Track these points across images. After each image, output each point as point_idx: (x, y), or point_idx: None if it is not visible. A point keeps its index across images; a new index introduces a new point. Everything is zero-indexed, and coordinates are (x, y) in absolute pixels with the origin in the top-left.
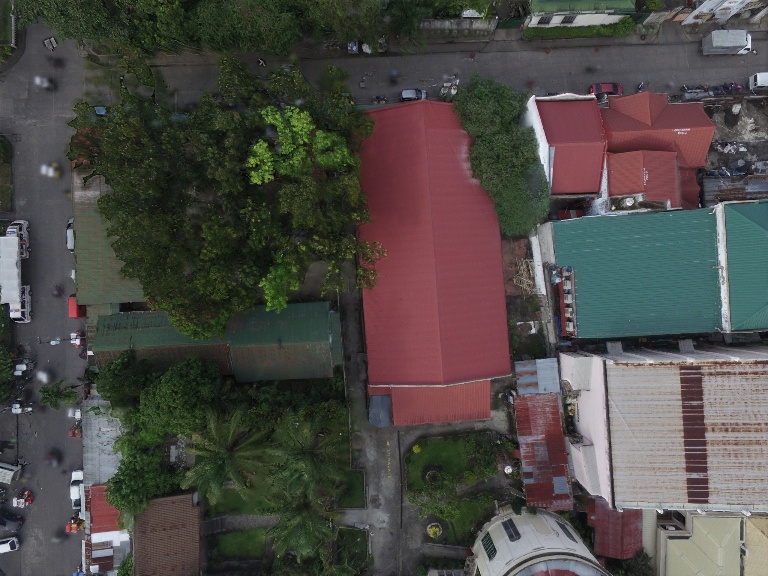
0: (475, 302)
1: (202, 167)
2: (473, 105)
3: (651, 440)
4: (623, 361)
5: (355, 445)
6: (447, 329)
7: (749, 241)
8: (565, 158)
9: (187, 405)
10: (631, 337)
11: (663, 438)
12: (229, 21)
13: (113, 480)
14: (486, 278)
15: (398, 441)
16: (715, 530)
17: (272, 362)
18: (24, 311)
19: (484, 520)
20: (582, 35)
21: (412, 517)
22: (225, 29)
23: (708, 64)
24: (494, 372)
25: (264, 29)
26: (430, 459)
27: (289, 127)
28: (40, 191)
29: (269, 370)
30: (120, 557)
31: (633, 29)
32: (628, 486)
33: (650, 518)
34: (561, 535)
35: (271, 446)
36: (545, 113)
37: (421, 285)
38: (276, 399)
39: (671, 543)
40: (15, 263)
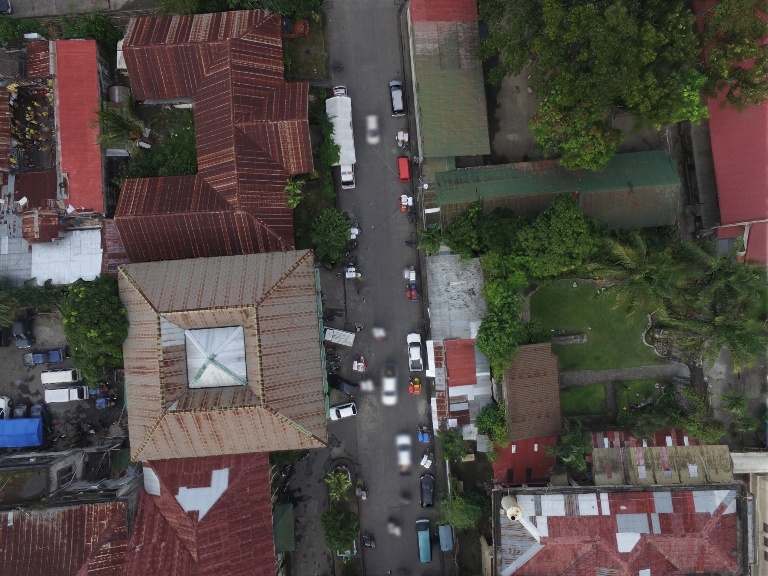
0: None
1: None
2: None
3: None
4: None
5: None
6: None
7: None
8: None
9: (587, 232)
10: None
11: None
12: None
13: (496, 320)
14: None
15: None
16: None
17: (618, 209)
18: (353, 175)
19: None
20: None
21: (749, 367)
22: None
23: None
24: None
25: None
26: (764, 308)
27: None
28: (355, 57)
29: (613, 219)
30: (475, 411)
31: None
32: None
33: None
34: None
35: None
36: None
37: None
38: None
39: None
40: (349, 123)
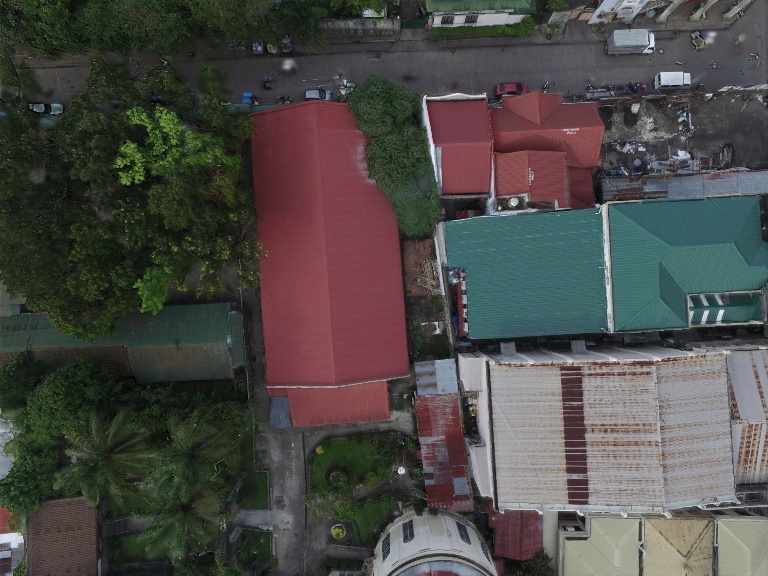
0: (370, 303)
1: None
2: (365, 105)
3: (533, 441)
4: (505, 362)
5: (259, 446)
6: (340, 330)
7: (631, 241)
8: (453, 158)
9: (70, 407)
10: (529, 337)
11: (544, 439)
12: (115, 22)
13: (2, 482)
14: (383, 279)
15: (303, 442)
16: (612, 531)
17: (171, 363)
18: None
19: (387, 521)
20: (487, 35)
21: (317, 518)
22: (112, 30)
23: (614, 64)
24: (390, 373)
25: (149, 29)
26: (335, 460)
27: (158, 128)
28: None
29: (169, 371)
30: (18, 559)
31: (538, 29)
32: (511, 487)
33: (550, 519)
34: (453, 536)
35: (154, 448)
36: (435, 113)
37: (314, 286)
38: (170, 400)
39: (569, 544)
40: None
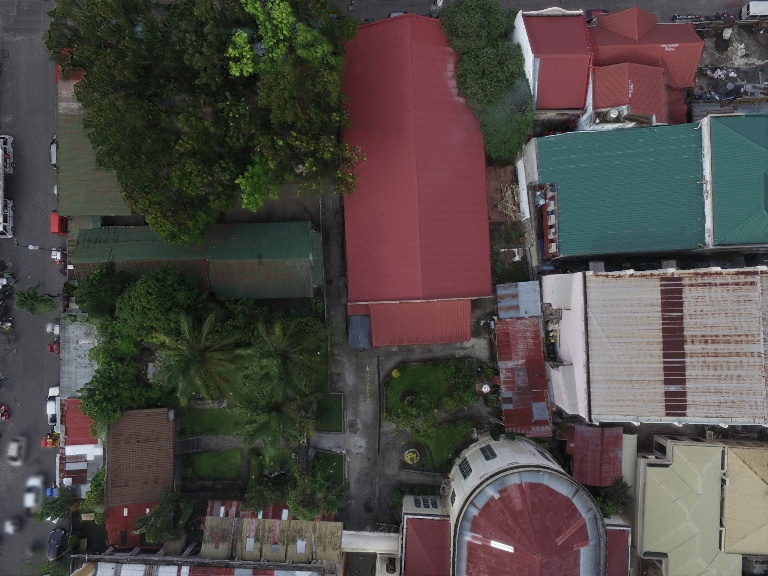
0: (457, 220)
1: (181, 60)
2: (459, 20)
3: (629, 352)
4: (603, 272)
5: (334, 368)
6: (427, 245)
7: (734, 153)
8: (550, 71)
9: (162, 307)
10: (615, 261)
11: (642, 350)
12: None
13: (87, 386)
14: (469, 198)
15: (378, 366)
16: (695, 458)
17: (252, 279)
18: (6, 225)
19: (462, 447)
20: None
21: (390, 443)
22: None
23: None
24: (475, 292)
25: None
26: (409, 385)
27: (269, 19)
28: (26, 107)
29: (249, 287)
30: (94, 471)
31: None
32: (605, 399)
33: (630, 447)
34: (538, 455)
35: (245, 351)
36: (531, 27)
37: (402, 200)
38: (254, 312)
39: (650, 471)
40: None
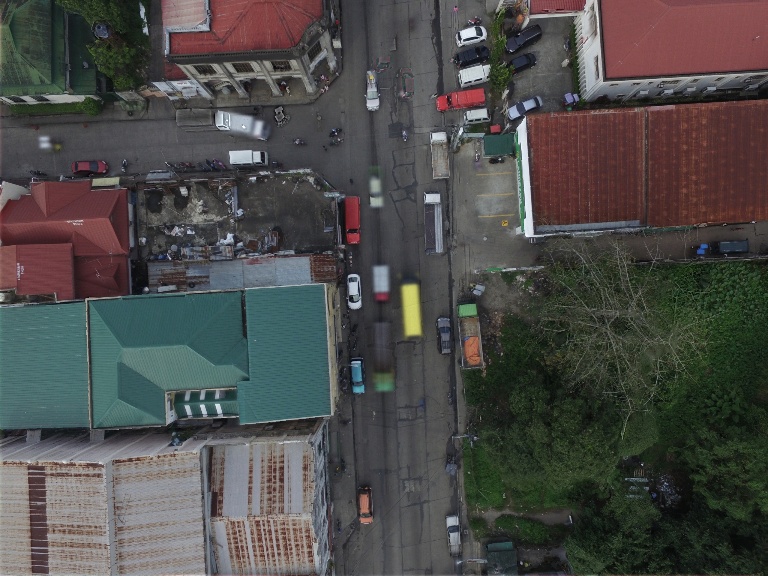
0: None
1: None
2: None
3: (4, 539)
4: None
5: None
6: None
7: (102, 339)
8: None
9: None
10: None
11: (14, 537)
12: None
13: None
14: None
15: None
16: None
17: None
18: None
19: None
20: (67, 112)
21: None
22: None
23: (197, 140)
24: None
25: None
26: None
27: None
28: None
29: None
30: None
31: None
32: None
33: None
34: None
35: None
36: None
37: None
38: None
39: None
40: None
